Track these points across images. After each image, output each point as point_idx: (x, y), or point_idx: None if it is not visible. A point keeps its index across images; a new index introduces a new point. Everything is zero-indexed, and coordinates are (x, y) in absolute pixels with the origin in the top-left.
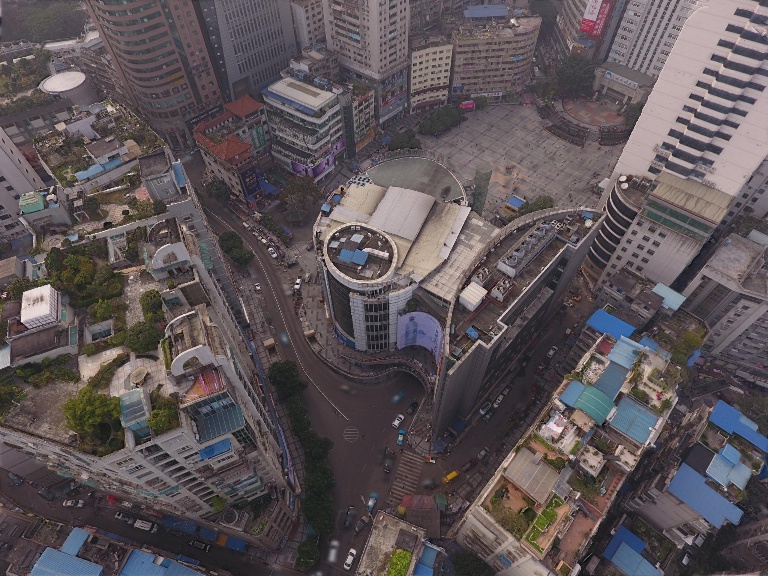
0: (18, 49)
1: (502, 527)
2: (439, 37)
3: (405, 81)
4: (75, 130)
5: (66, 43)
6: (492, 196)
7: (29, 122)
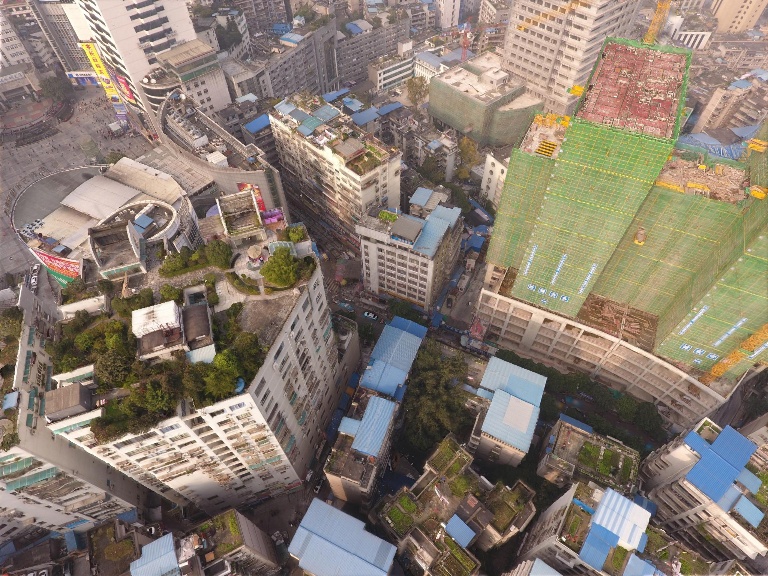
0: None
1: (373, 169)
2: None
3: None
4: None
5: None
6: None
7: None
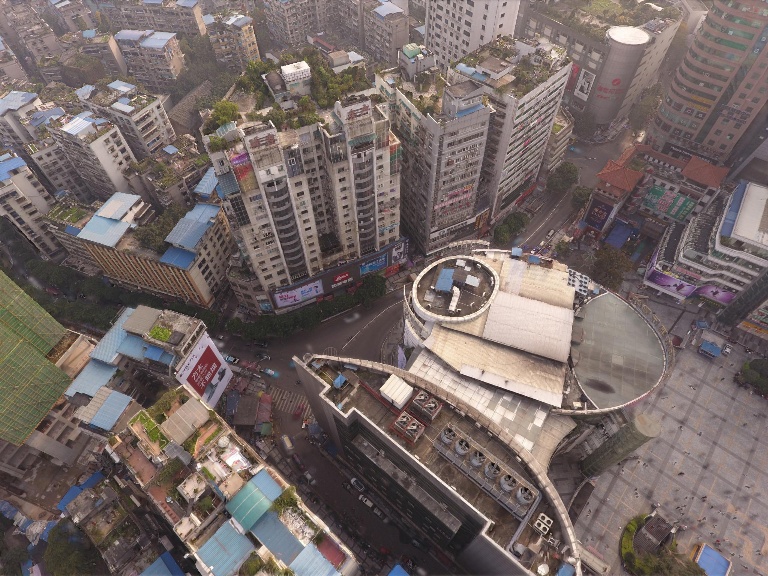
0: None
1: None
2: None
3: None
4: (519, 48)
5: None
6: (722, 527)
7: (575, 43)
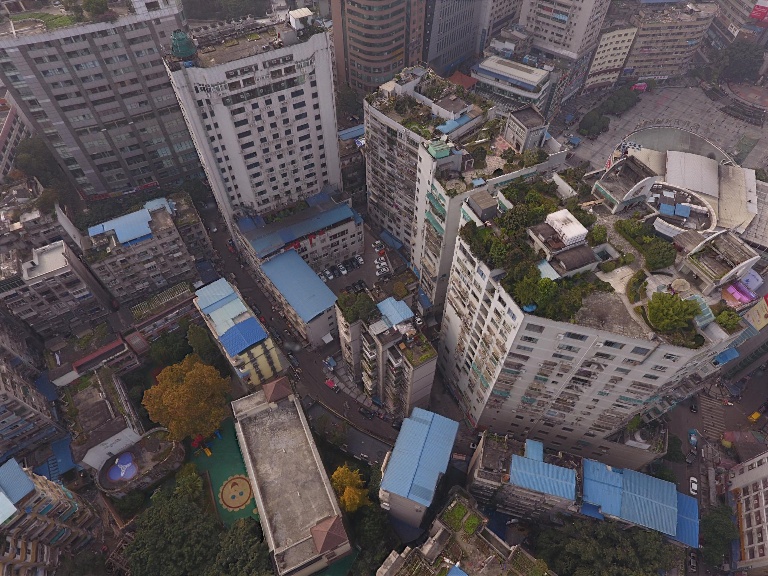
0: (246, 24)
1: None
2: (623, 20)
3: (588, 62)
4: (404, 91)
5: (262, 21)
6: None
7: None
